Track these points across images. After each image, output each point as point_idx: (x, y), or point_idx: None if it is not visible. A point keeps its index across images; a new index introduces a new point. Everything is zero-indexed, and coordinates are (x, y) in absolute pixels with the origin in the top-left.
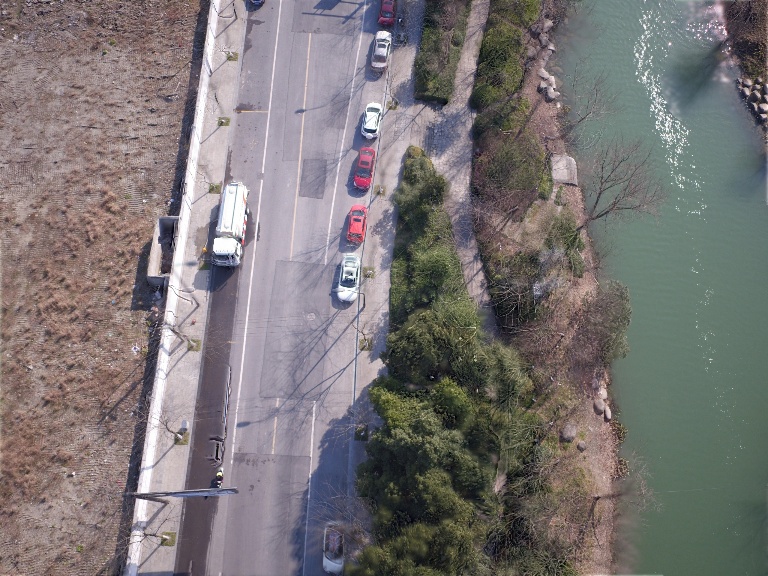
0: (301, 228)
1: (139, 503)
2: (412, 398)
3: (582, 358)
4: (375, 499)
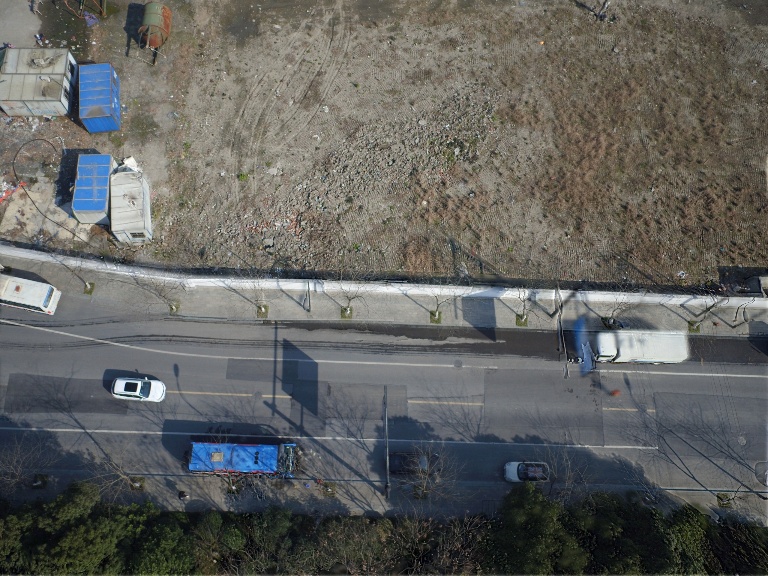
0: None
1: (551, 293)
2: (708, 553)
3: None
4: (598, 513)
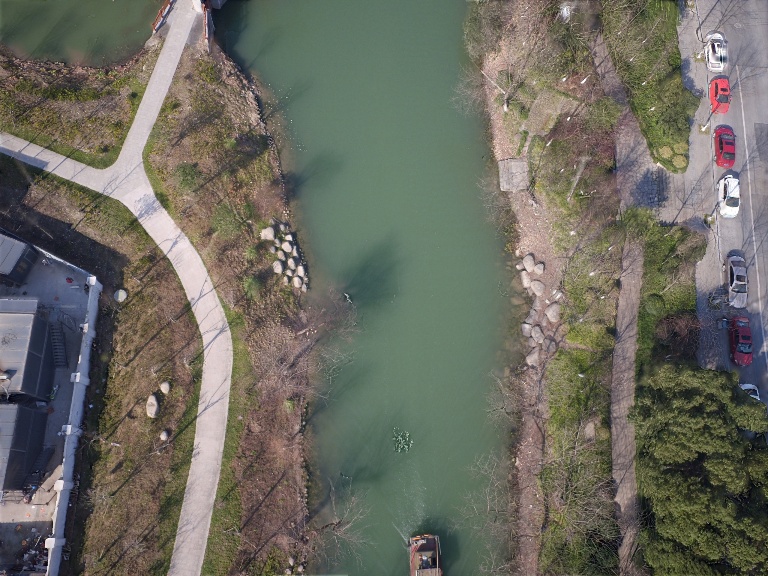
0: (766, 96)
1: None
2: None
3: (501, 8)
4: None
